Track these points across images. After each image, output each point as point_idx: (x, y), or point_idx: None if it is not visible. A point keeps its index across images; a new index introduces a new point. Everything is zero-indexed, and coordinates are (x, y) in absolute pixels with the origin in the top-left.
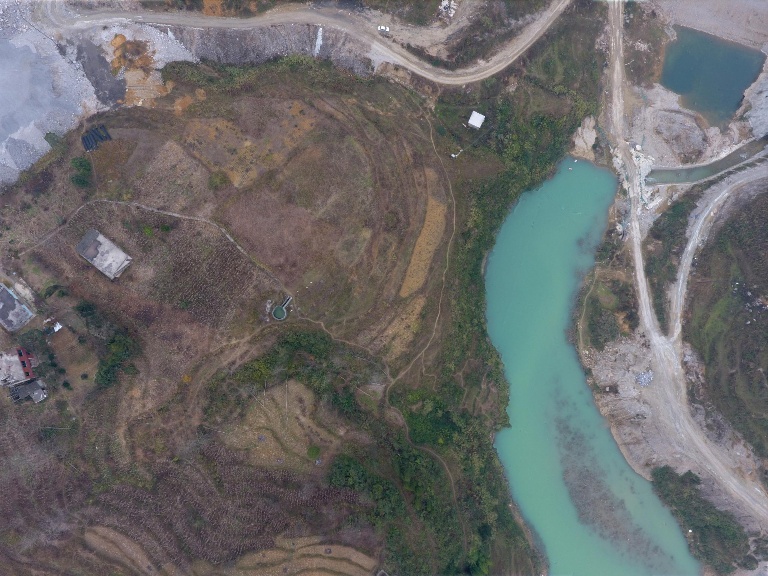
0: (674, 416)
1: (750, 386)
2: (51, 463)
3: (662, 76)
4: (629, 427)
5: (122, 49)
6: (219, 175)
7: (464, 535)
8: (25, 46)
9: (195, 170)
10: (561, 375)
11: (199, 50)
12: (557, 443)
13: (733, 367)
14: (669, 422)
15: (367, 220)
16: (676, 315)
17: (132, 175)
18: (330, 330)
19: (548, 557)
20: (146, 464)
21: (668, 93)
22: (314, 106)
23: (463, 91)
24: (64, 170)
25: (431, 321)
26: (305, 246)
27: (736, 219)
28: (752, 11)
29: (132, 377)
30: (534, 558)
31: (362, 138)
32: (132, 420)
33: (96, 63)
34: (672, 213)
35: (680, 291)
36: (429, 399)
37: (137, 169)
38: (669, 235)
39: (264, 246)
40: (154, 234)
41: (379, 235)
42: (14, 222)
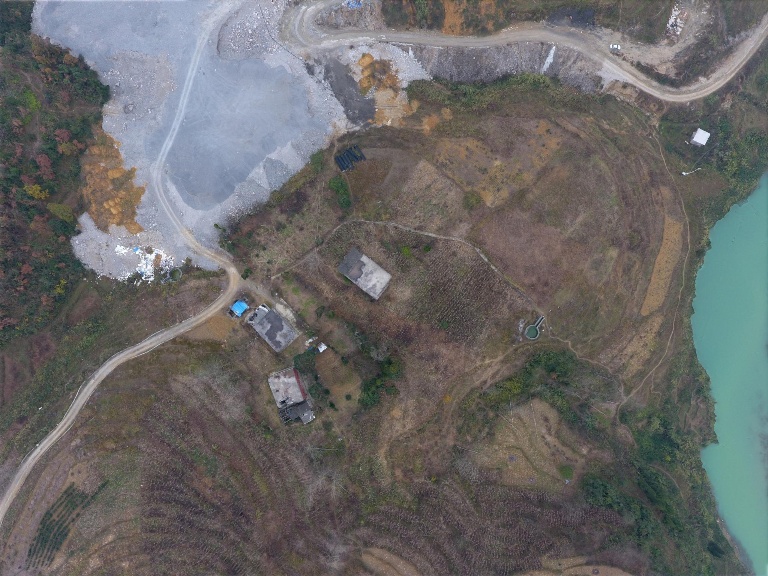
0: None
1: None
2: (323, 484)
3: None
4: None
5: (372, 69)
6: (475, 195)
7: (700, 553)
8: (281, 66)
9: (450, 190)
10: (762, 390)
11: (434, 68)
12: (762, 459)
13: None
14: None
15: (614, 239)
16: None
17: (389, 195)
18: (576, 349)
19: (755, 573)
20: (406, 484)
21: None
22: (560, 125)
23: (689, 109)
24: (318, 190)
25: (665, 339)
26: (556, 265)
27: None
28: None
29: (393, 397)
30: (745, 574)
31: (605, 157)
32: (394, 440)
33: (344, 83)
34: None
35: None
36: (655, 416)
37: (394, 189)
38: None
39: (517, 266)
40: (412, 254)
41: (623, 254)
42: (270, 242)
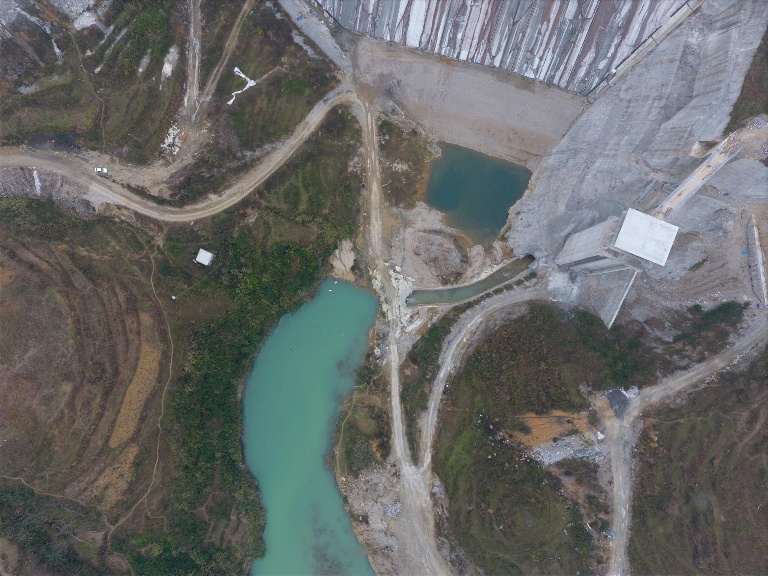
0: (420, 550)
1: (483, 526)
2: None
3: (427, 194)
4: (381, 558)
5: None
6: None
7: None
8: None
9: None
10: (322, 500)
11: None
12: (314, 572)
13: (470, 504)
14: (415, 556)
15: (67, 374)
16: (426, 444)
17: None
18: (32, 485)
19: None
20: None
21: (430, 212)
22: (14, 258)
23: (189, 229)
24: None
25: (149, 467)
26: None
27: (480, 349)
28: (511, 130)
29: None
30: None
31: (66, 288)
32: None
33: None
34: (428, 337)
35: (430, 420)
36: (158, 542)
37: None
38: (423, 361)
39: None
40: None
41: (83, 387)
42: None
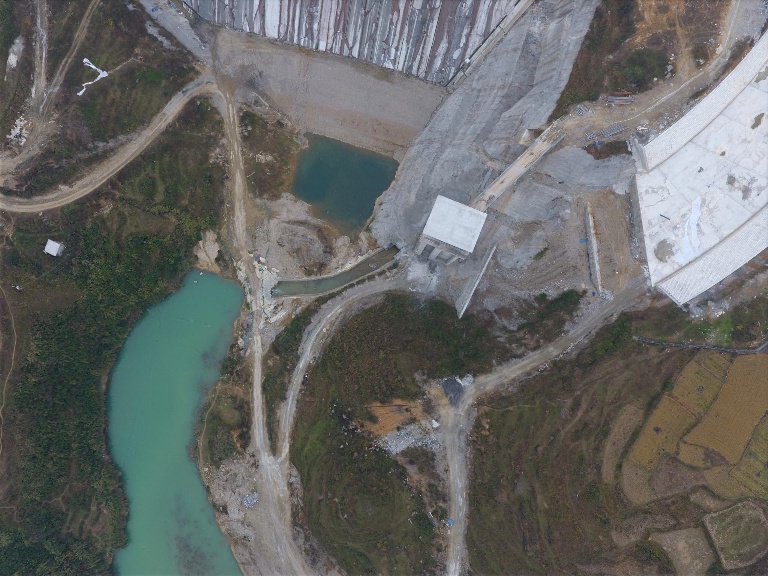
0: (276, 539)
1: (331, 515)
2: None
3: (294, 185)
4: (241, 548)
5: None
6: None
7: None
8: None
9: None
10: (187, 491)
11: None
12: (177, 562)
13: (321, 494)
14: (271, 546)
15: None
16: (284, 435)
17: None
18: None
19: None
20: None
21: (295, 203)
22: None
23: (37, 220)
24: None
25: None
26: None
27: (335, 339)
28: (375, 121)
29: None
30: None
31: None
32: None
33: None
34: (291, 328)
35: (289, 410)
36: (7, 532)
37: None
38: (284, 351)
39: None
40: None
41: None
42: None
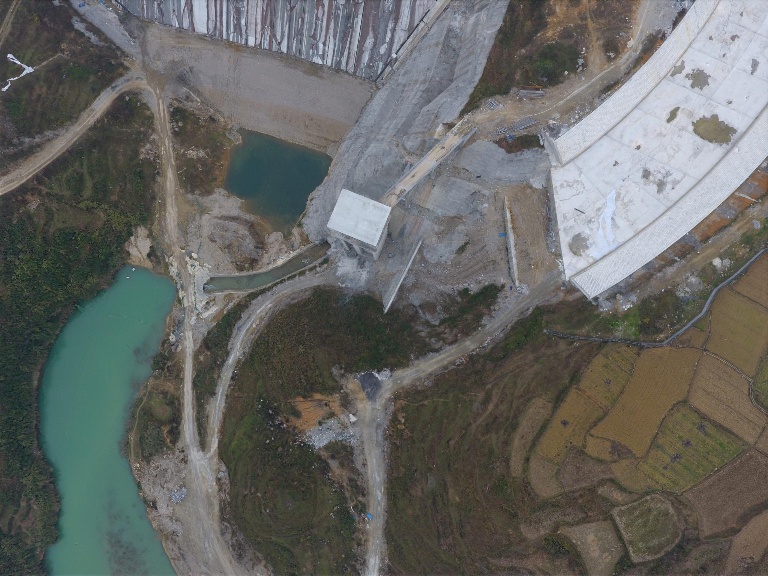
0: (204, 534)
1: (255, 510)
2: None
3: (227, 180)
4: (171, 543)
5: None
6: None
7: None
8: None
9: None
10: (119, 487)
11: None
12: (108, 558)
13: (246, 488)
14: (199, 541)
15: None
16: (213, 430)
17: None
18: None
19: None
20: None
21: (228, 199)
22: None
23: None
24: None
25: None
26: None
27: (262, 335)
28: (307, 116)
29: None
30: None
31: None
32: None
33: None
34: (222, 323)
35: (218, 405)
36: None
37: None
38: (214, 347)
39: None
40: None
41: None
42: None
